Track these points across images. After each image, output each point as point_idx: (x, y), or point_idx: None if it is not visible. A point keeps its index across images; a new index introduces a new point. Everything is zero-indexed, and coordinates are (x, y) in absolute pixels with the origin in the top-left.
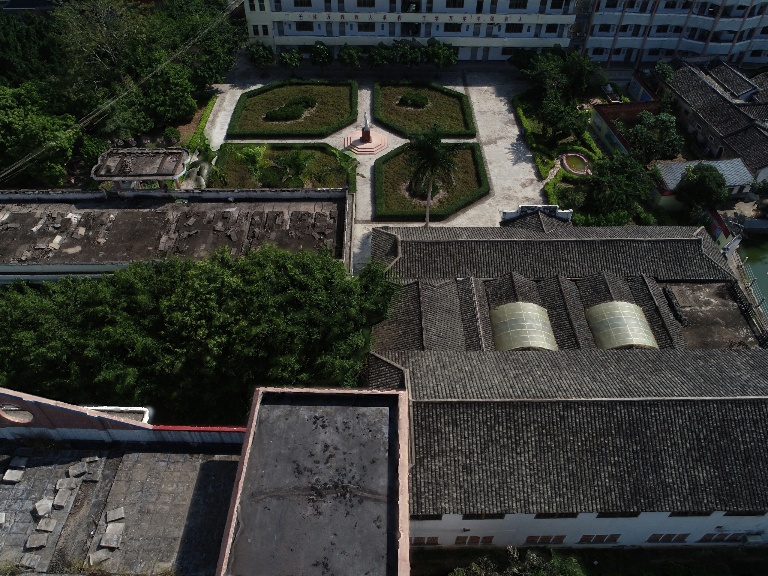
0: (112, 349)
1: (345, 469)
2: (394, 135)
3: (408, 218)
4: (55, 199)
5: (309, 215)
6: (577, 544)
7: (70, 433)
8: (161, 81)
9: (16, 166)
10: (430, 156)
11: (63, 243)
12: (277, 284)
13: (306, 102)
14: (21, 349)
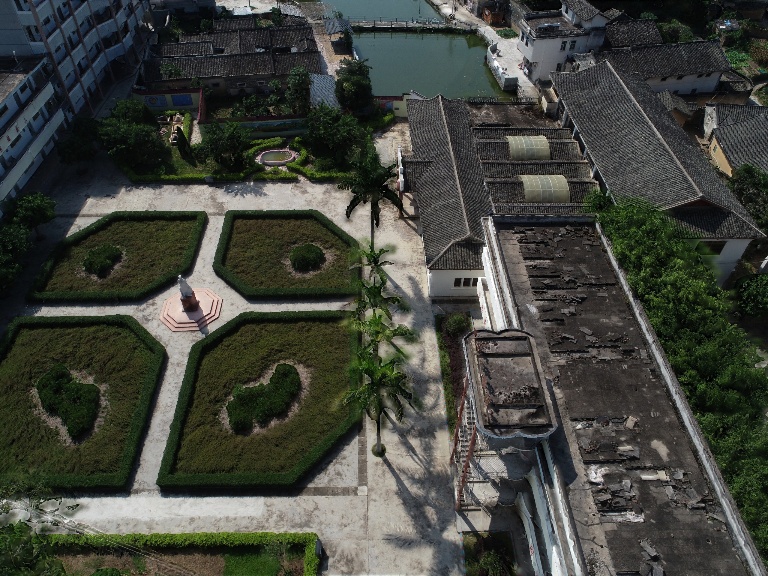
0: None
1: None
2: None
3: None
4: None
5: None
6: None
7: None
8: None
9: None
10: None
11: (654, 465)
12: None
13: (60, 377)
14: None
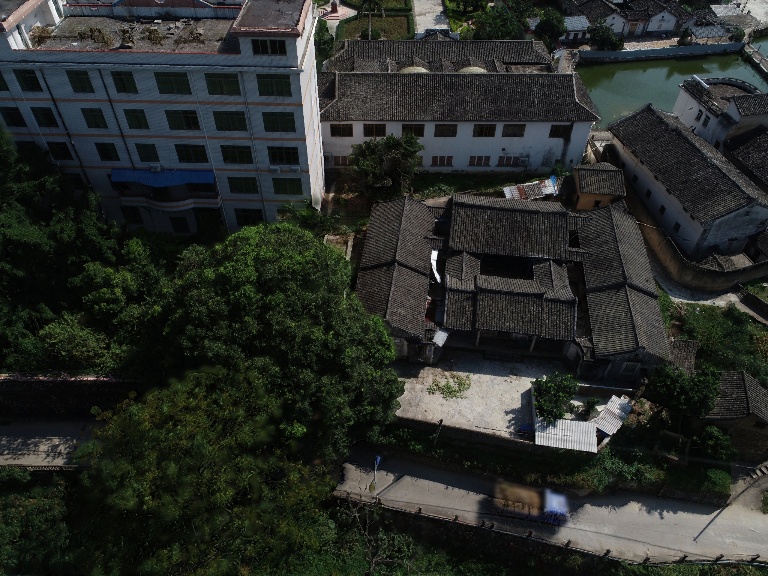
0: None
1: None
2: (355, 10)
3: None
4: None
5: None
6: (431, 167)
7: (179, 11)
8: None
9: None
10: None
11: None
12: None
13: None
14: None
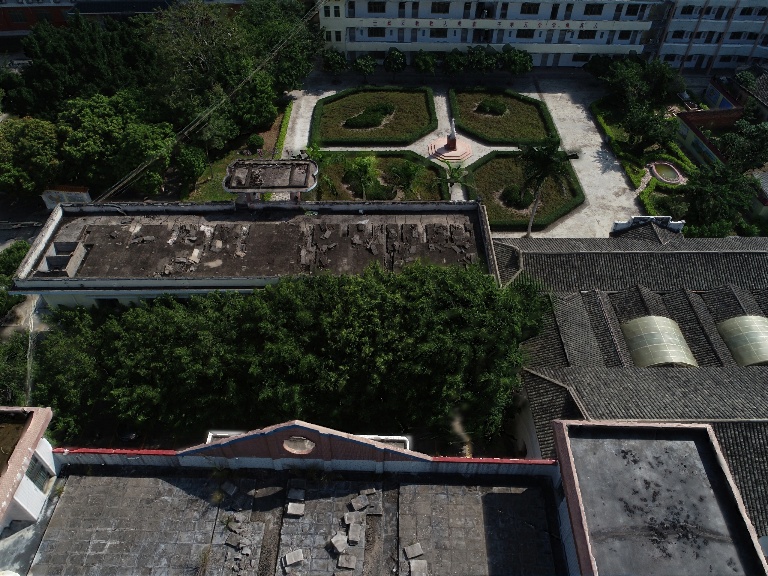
0: (272, 366)
1: (676, 507)
2: (477, 143)
3: (507, 228)
4: (183, 211)
5: (444, 228)
6: None
7: (343, 464)
8: (247, 88)
9: (131, 176)
10: (544, 166)
11: (203, 256)
12: (437, 300)
13: (384, 109)
14: (174, 365)
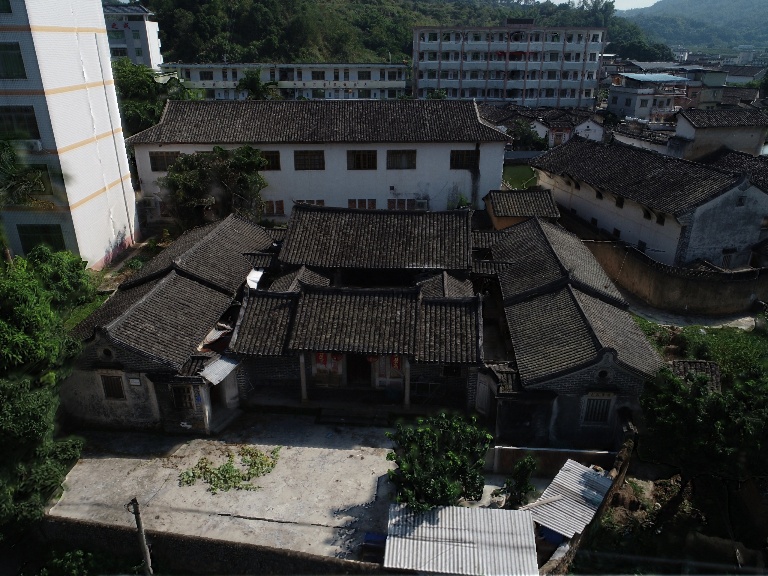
0: None
1: None
2: None
3: None
4: None
5: None
6: None
7: None
8: None
9: None
10: (254, 88)
11: None
12: None
13: None
14: None
